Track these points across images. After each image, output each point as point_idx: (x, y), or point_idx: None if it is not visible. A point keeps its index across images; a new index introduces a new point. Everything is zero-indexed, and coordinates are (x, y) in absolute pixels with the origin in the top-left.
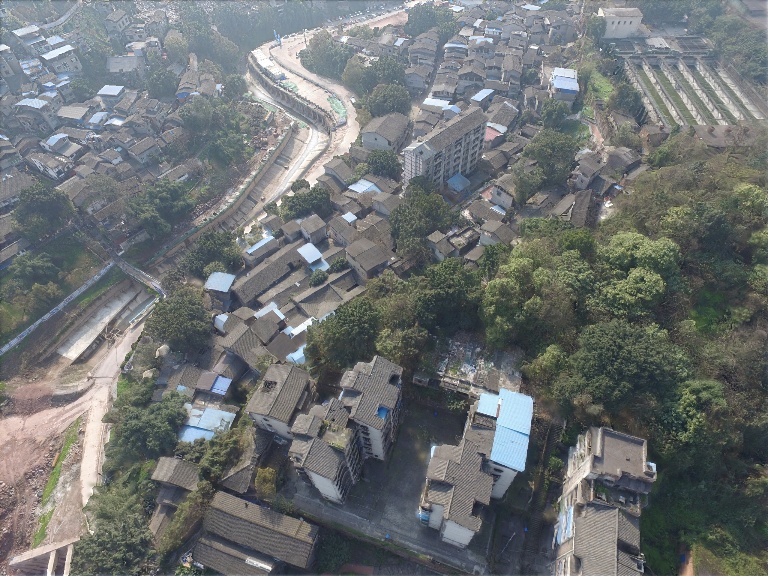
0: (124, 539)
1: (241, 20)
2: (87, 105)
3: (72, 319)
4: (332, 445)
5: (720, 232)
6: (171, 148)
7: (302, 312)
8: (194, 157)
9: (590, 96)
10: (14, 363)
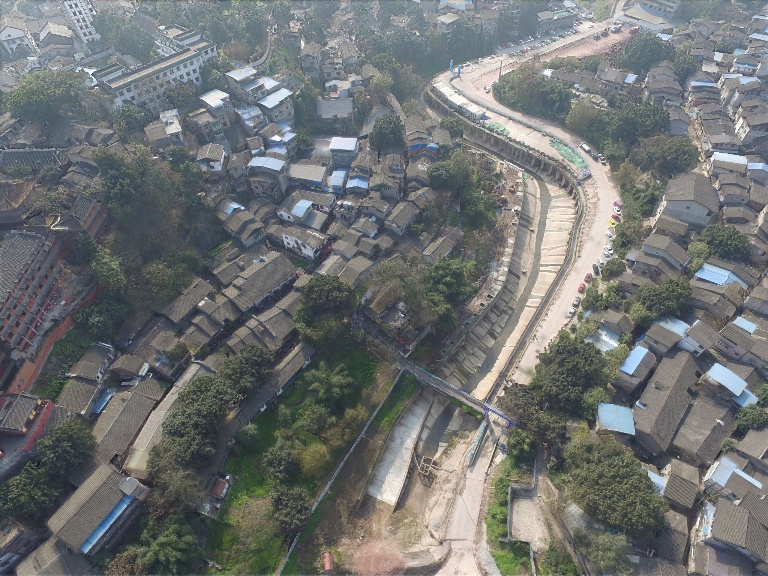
0: None
1: (416, 49)
2: (319, 162)
3: (380, 449)
4: None
5: None
6: (429, 215)
7: (762, 470)
8: (446, 223)
9: None
10: (333, 516)
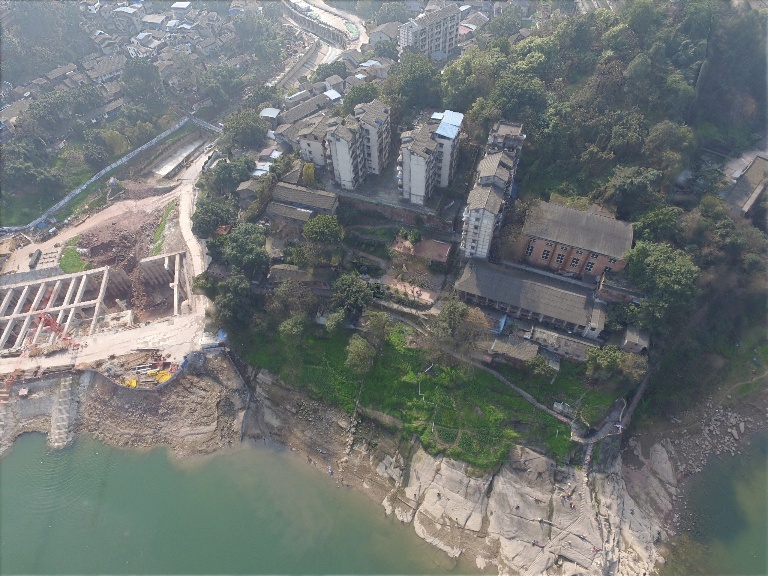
0: (225, 207)
1: None
2: (164, 15)
3: (162, 150)
4: (349, 128)
5: (583, 33)
6: (227, 46)
7: None
8: None
9: (540, 4)
10: (125, 172)
